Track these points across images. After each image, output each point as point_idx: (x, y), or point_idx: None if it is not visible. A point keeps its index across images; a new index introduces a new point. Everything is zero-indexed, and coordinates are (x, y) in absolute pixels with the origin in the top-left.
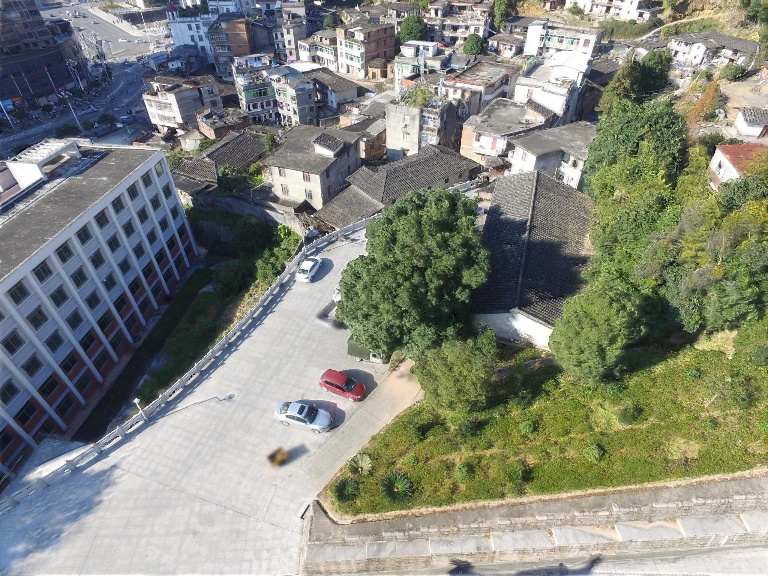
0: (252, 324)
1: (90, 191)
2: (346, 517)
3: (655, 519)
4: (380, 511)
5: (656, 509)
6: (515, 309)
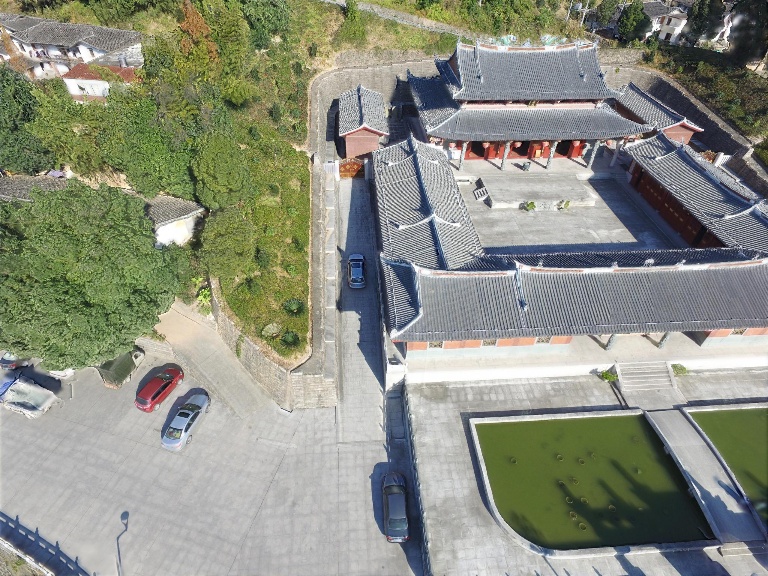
0: None
1: None
2: (308, 349)
3: (325, 215)
4: None
5: (322, 209)
6: (156, 225)
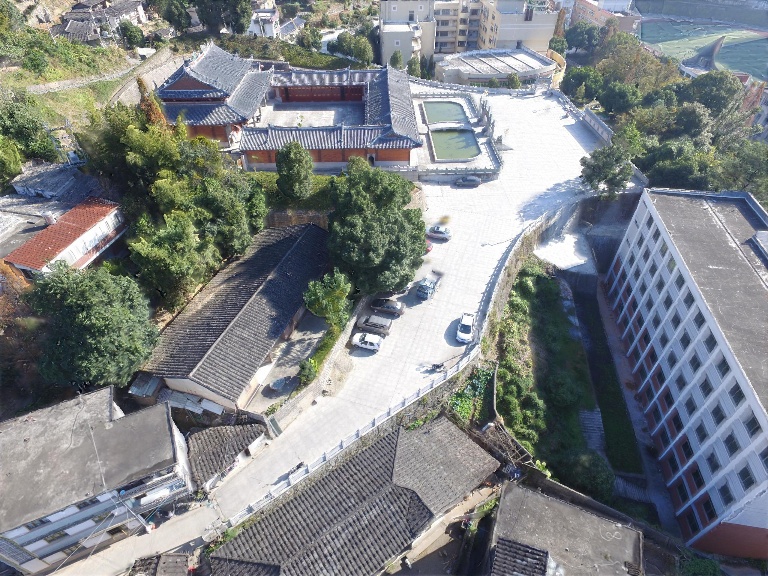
0: (494, 284)
1: (762, 356)
2: None
3: None
4: None
5: None
6: None
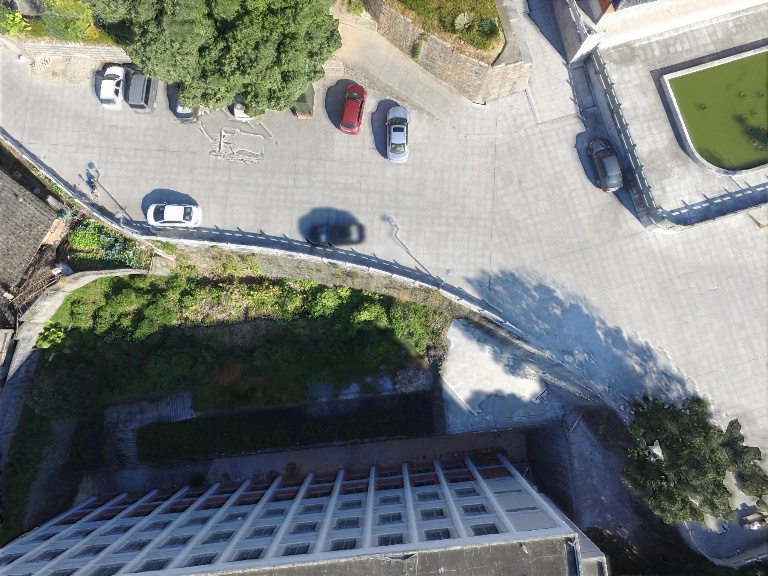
0: (288, 248)
1: None
2: None
3: None
4: (494, 3)
5: None
6: None
